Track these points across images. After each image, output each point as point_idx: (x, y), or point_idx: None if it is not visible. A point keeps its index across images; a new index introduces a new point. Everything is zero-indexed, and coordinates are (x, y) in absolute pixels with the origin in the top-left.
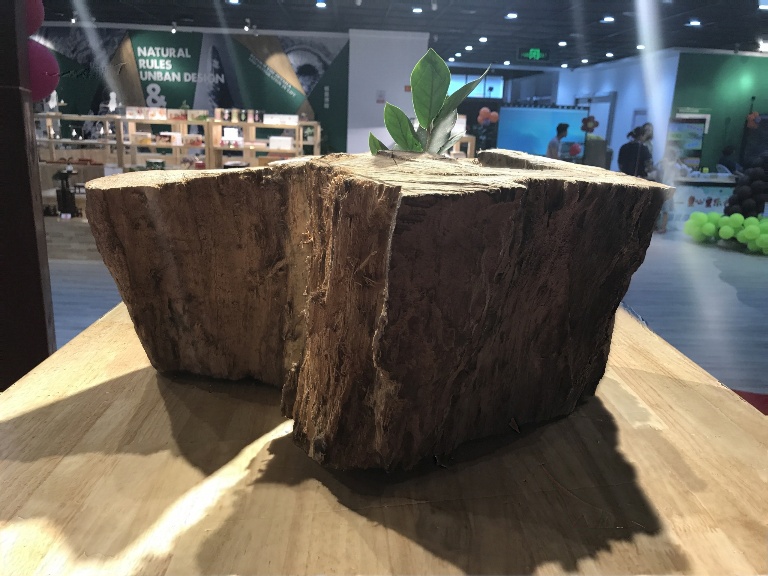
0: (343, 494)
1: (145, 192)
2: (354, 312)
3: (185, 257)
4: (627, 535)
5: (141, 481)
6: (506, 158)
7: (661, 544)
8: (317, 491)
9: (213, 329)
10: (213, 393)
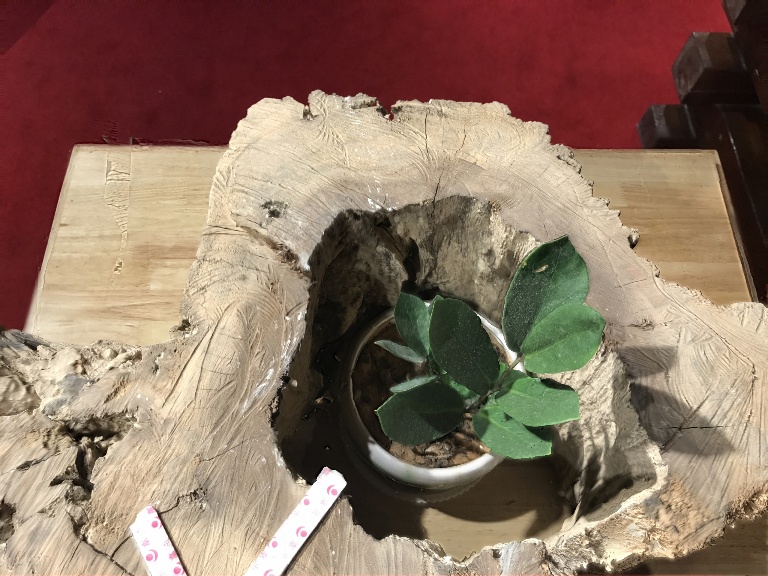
0: None
1: None
2: None
3: None
4: None
5: None
6: (326, 234)
7: None
8: None
9: None
10: None
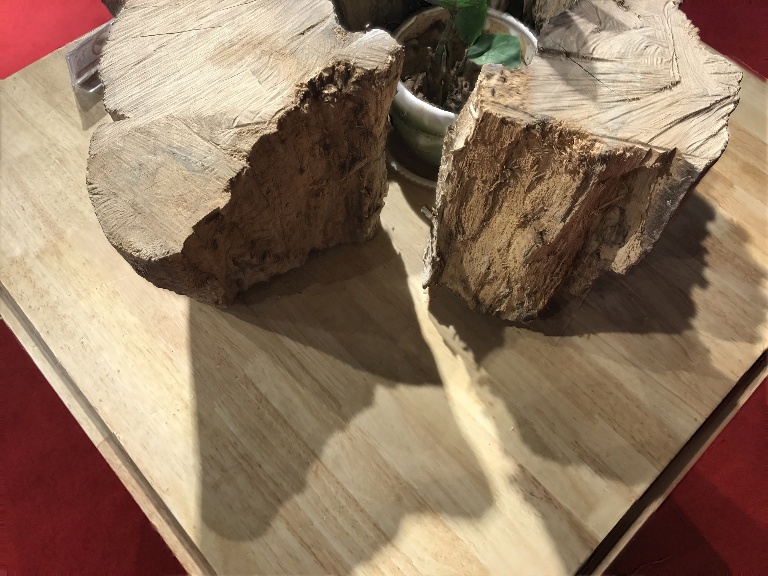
0: (540, 326)
1: (220, 212)
2: (576, 235)
3: (250, 220)
4: (704, 230)
5: (411, 430)
6: None
7: (725, 225)
8: (523, 337)
9: (282, 248)
10: (305, 292)
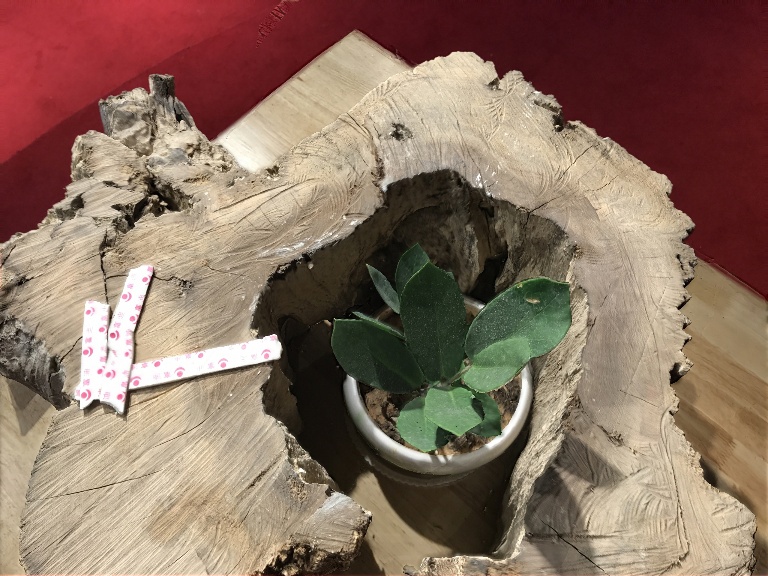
0: None
1: None
2: None
3: None
4: None
5: None
6: (422, 177)
7: None
8: None
9: None
10: None
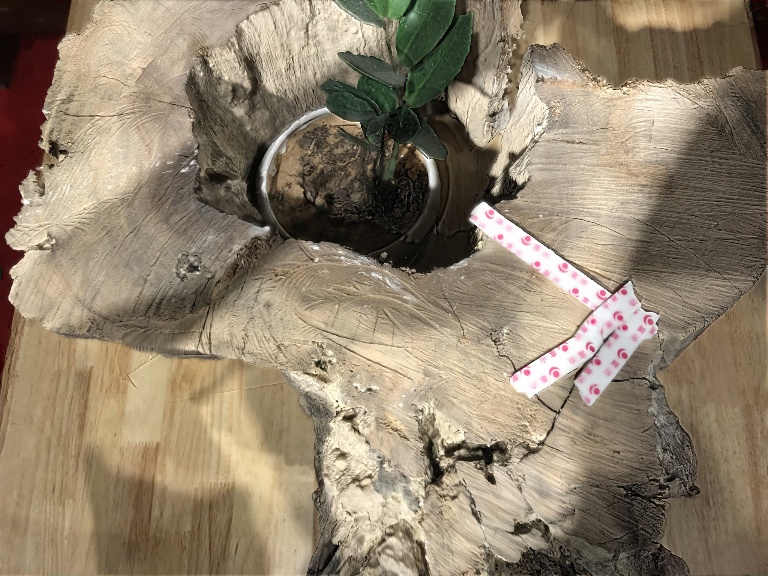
0: None
1: None
2: None
3: None
4: None
5: (589, 66)
6: None
7: None
8: None
9: None
10: None
